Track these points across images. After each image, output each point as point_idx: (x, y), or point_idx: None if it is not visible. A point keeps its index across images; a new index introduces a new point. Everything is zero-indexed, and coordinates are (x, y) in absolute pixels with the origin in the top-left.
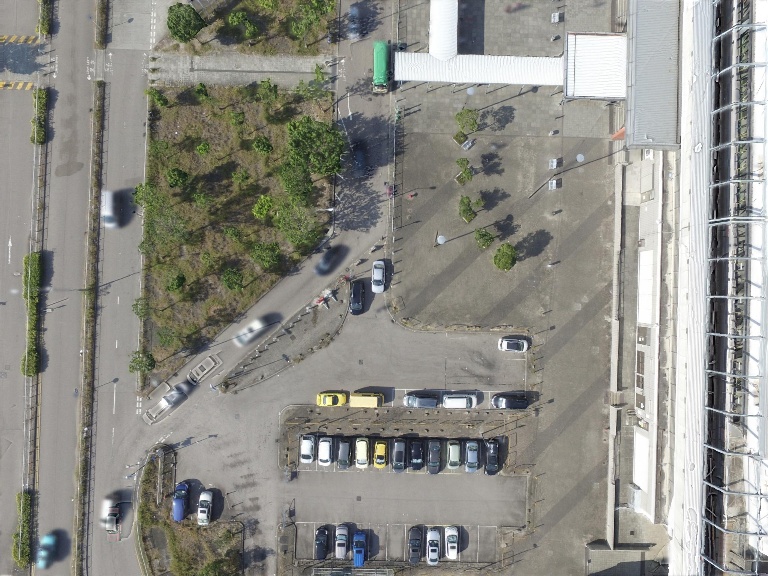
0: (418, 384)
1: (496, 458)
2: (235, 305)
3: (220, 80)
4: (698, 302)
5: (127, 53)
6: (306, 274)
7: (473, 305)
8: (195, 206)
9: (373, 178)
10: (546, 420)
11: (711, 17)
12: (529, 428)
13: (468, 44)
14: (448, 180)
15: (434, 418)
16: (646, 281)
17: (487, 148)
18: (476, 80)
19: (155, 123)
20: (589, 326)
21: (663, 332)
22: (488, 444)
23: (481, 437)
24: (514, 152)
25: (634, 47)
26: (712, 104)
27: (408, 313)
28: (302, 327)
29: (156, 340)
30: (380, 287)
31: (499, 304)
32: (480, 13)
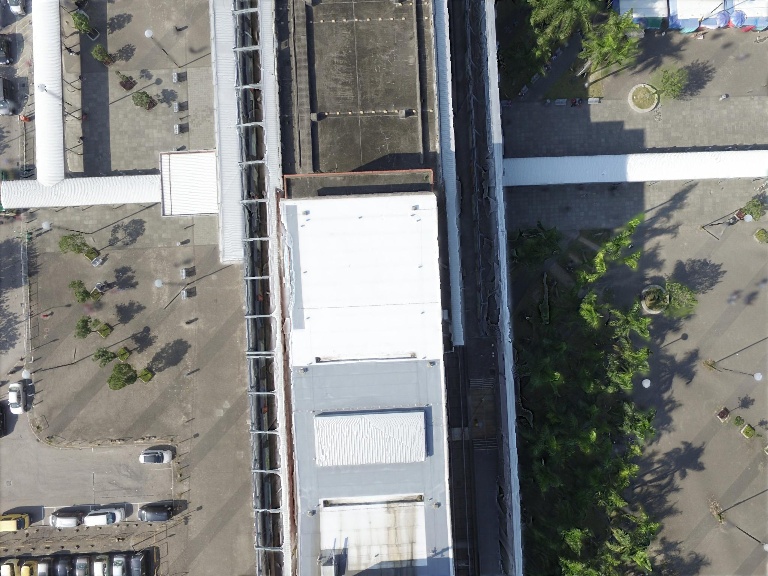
0: (67, 501)
1: (140, 572)
2: None
3: None
4: None
5: None
6: None
7: (116, 419)
8: None
9: (9, 300)
10: (196, 528)
11: (239, 148)
12: (179, 537)
13: (95, 161)
14: None
15: (84, 534)
16: None
17: (120, 262)
18: (85, 202)
19: None
20: (232, 431)
21: None
22: (132, 558)
23: (132, 549)
24: (147, 264)
25: (219, 165)
26: (247, 233)
27: (52, 431)
28: None
29: None
30: (18, 409)
31: (141, 416)
32: (105, 129)
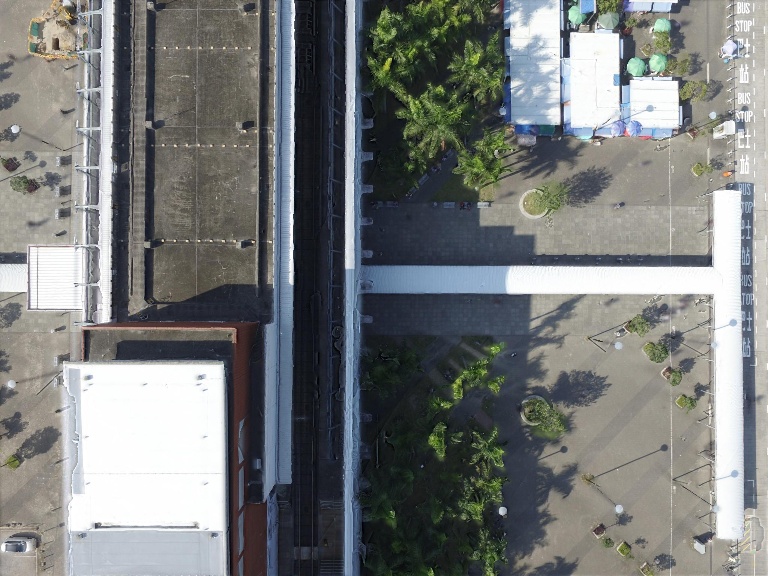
0: None
1: None
2: None
3: None
4: None
5: None
6: None
7: None
8: None
9: None
10: None
11: None
12: None
13: None
14: None
15: None
16: None
17: None
18: None
19: None
20: None
21: None
22: None
23: None
24: (21, 349)
25: None
26: None
27: None
28: None
29: None
30: None
31: (8, 502)
32: None
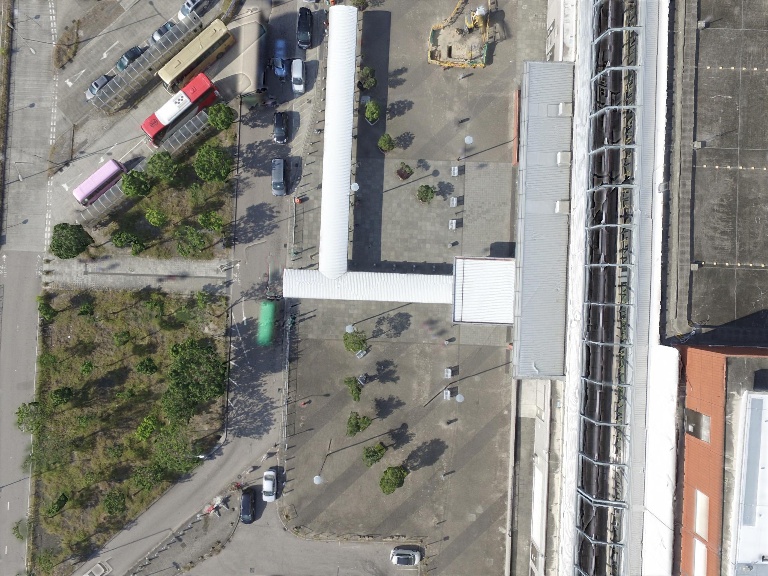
0: None
1: None
2: (125, 512)
3: (114, 283)
4: (569, 564)
5: (21, 255)
6: (198, 481)
7: (366, 514)
8: (87, 411)
9: (267, 384)
10: None
11: (583, 279)
12: None
13: (365, 249)
14: (342, 387)
15: None
16: (538, 500)
17: (382, 355)
18: (366, 298)
19: (48, 327)
20: (483, 537)
21: (549, 564)
22: None
23: None
24: (410, 359)
25: (521, 277)
26: (583, 368)
27: (300, 521)
28: (193, 535)
29: (46, 546)
30: (271, 497)
31: (392, 514)
32: (377, 218)
